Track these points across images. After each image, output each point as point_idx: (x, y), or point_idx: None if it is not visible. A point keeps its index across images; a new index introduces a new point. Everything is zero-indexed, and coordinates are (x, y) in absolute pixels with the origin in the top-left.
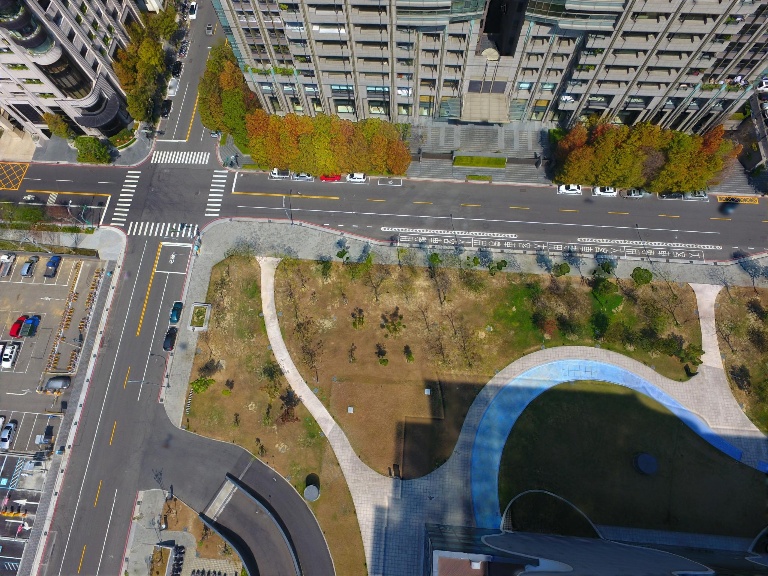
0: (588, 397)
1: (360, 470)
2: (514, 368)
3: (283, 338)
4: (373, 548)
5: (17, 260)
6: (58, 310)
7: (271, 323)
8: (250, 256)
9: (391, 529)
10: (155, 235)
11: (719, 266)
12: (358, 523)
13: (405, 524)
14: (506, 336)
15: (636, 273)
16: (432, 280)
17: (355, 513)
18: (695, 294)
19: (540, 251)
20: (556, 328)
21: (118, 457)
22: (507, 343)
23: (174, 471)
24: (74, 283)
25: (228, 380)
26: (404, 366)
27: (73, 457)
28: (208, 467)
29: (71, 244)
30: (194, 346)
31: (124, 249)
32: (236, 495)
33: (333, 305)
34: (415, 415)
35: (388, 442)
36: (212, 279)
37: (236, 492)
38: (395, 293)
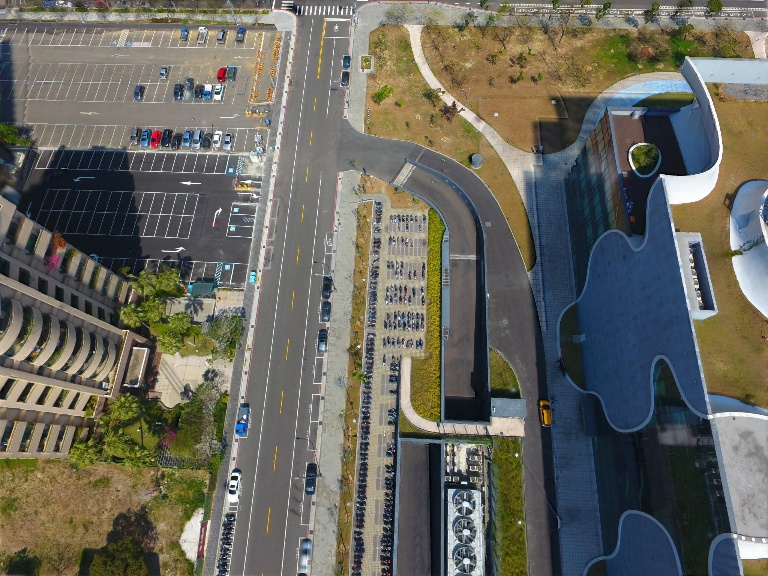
0: (676, 102)
1: (509, 150)
2: (617, 86)
3: (434, 75)
4: (527, 194)
5: (209, 33)
6: (250, 64)
7: (423, 67)
8: (399, 25)
9: (539, 183)
10: (319, 14)
11: (766, 20)
12: (513, 180)
13: (549, 180)
14: (608, 68)
15: (711, 2)
16: (546, 35)
17: (510, 175)
18: (749, 38)
19: (627, 15)
20: (646, 62)
21: (318, 152)
22: (610, 72)
23: (364, 159)
24: (260, 46)
25: (396, 102)
26: (533, 88)
27: (282, 154)
28: (390, 156)
29: (252, 21)
30: (365, 82)
31: (296, 24)
32: (415, 172)
33: (471, 53)
34: (546, 116)
35: (528, 133)
36: (371, 40)
37: (414, 170)
38: (518, 44)
